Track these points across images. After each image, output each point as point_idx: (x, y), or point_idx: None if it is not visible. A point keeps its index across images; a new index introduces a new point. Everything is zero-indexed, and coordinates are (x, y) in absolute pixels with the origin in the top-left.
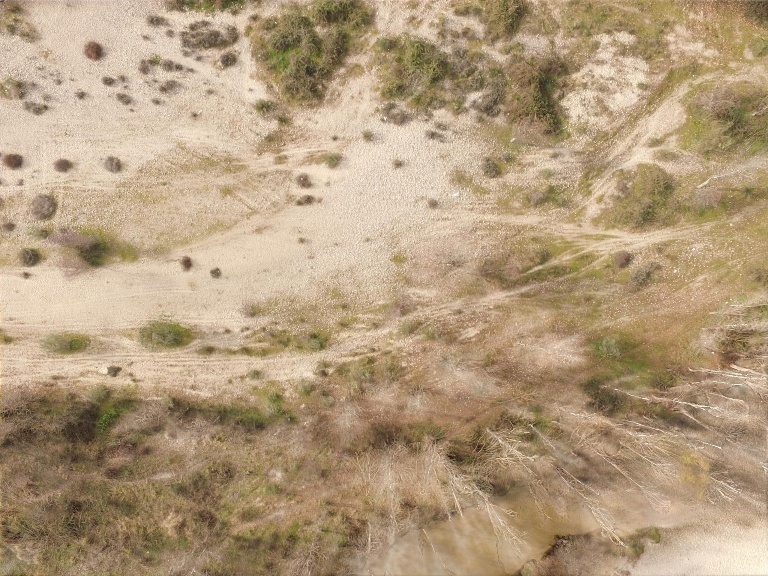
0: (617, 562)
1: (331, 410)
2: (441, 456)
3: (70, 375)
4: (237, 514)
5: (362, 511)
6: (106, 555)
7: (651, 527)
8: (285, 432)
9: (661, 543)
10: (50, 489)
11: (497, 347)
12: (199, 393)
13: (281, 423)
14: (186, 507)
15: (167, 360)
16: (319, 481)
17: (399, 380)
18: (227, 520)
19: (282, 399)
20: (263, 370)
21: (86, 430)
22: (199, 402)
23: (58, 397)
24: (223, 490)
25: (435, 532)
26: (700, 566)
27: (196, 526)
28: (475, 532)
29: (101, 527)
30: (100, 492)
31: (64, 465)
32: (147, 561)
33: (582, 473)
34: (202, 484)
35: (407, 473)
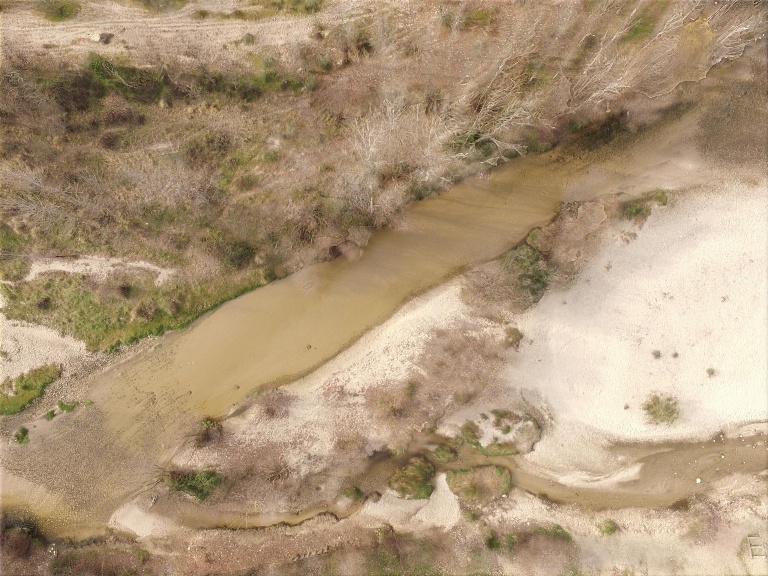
0: (624, 226)
1: (328, 74)
2: (442, 117)
3: (62, 43)
4: (236, 182)
5: (363, 176)
6: (104, 227)
7: (658, 190)
8: (282, 99)
9: (668, 205)
10: (45, 160)
11: (495, 5)
12: (193, 60)
13: (278, 89)
14: (184, 177)
15: (160, 26)
16: (318, 148)
17: (397, 42)
18: (226, 189)
19: (278, 64)
20: (258, 34)
21: (80, 96)
22: (194, 69)
23: (50, 66)
24: (221, 158)
25: (438, 203)
26: (709, 225)
27: (195, 191)
28: (479, 201)
29: (98, 198)
30: (96, 163)
31: (59, 136)
32: (146, 231)
33: (586, 139)
34: (199, 152)
35: (408, 137)
